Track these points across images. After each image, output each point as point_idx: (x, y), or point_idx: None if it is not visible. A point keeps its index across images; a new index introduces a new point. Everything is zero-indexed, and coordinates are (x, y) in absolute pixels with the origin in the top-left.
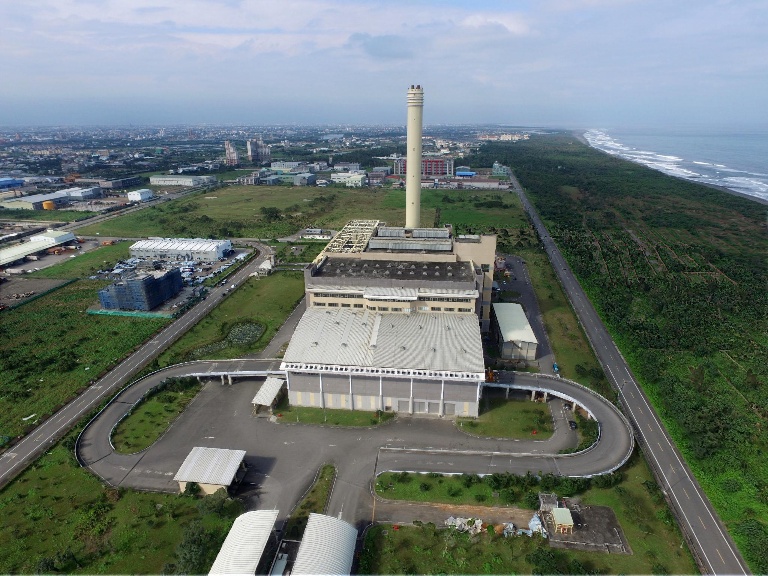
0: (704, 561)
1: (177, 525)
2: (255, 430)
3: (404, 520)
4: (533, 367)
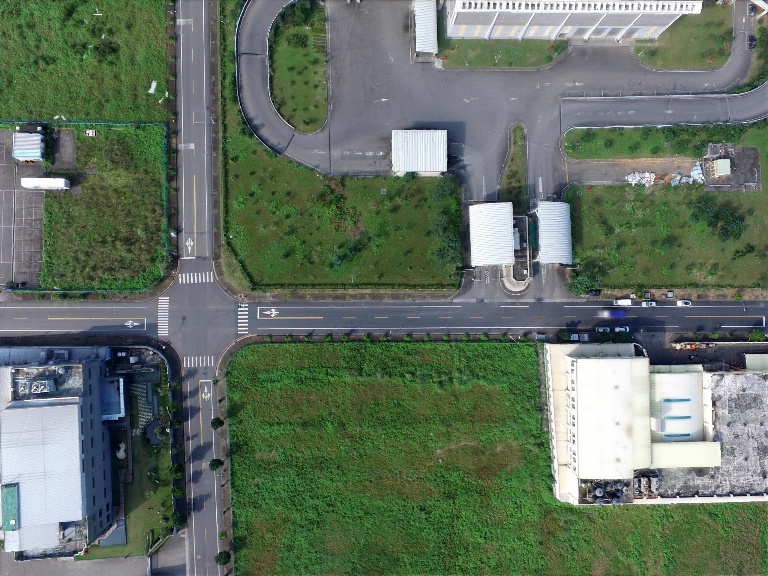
0: None
1: (411, 207)
2: (426, 84)
3: (593, 179)
4: None
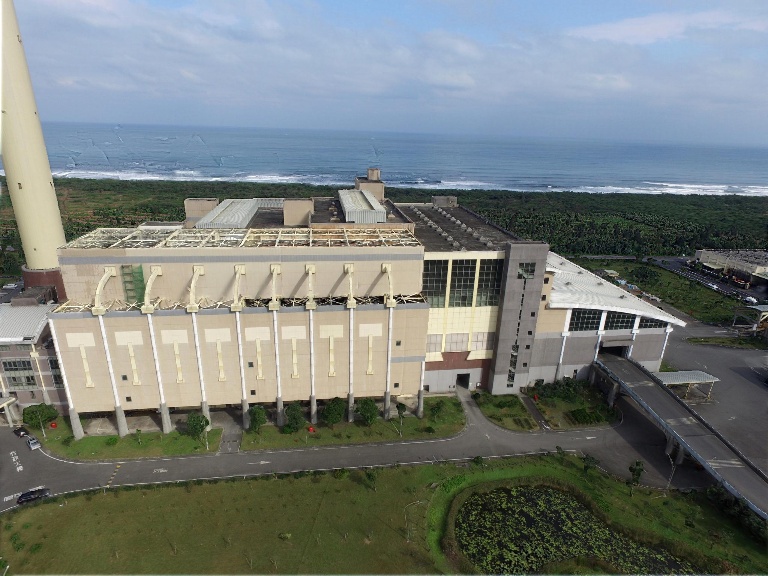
0: None
1: None
2: (727, 391)
3: None
4: None
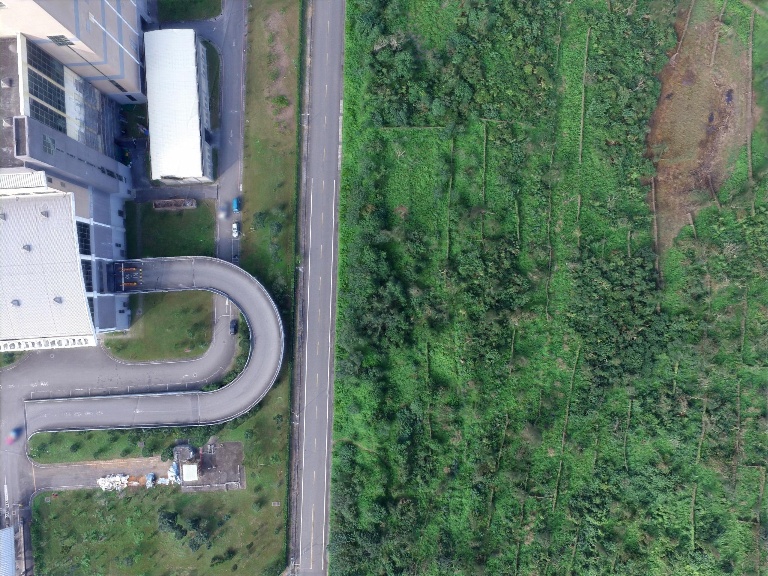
0: (299, 485)
1: None
2: None
3: (62, 485)
4: (208, 203)
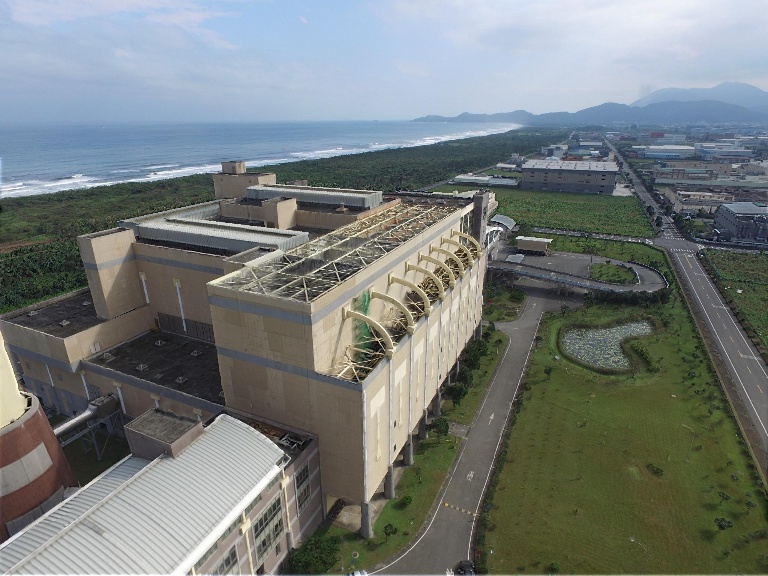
0: None
1: None
2: None
3: None
4: None
